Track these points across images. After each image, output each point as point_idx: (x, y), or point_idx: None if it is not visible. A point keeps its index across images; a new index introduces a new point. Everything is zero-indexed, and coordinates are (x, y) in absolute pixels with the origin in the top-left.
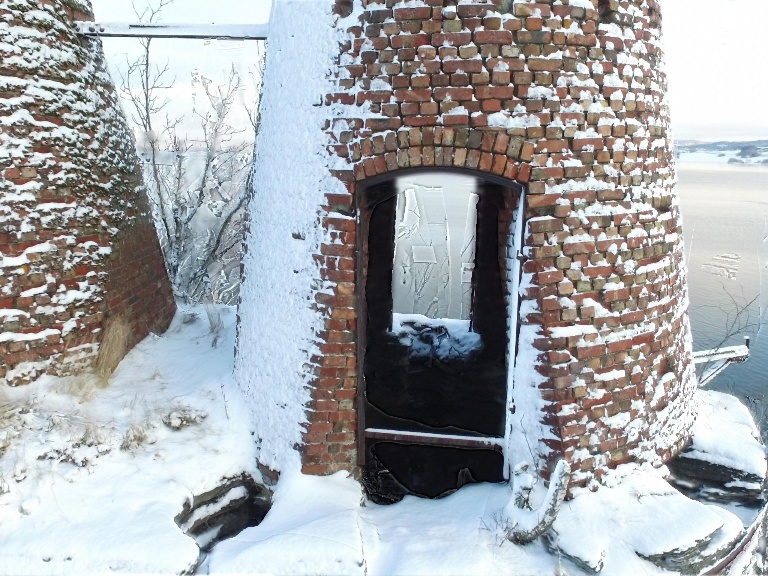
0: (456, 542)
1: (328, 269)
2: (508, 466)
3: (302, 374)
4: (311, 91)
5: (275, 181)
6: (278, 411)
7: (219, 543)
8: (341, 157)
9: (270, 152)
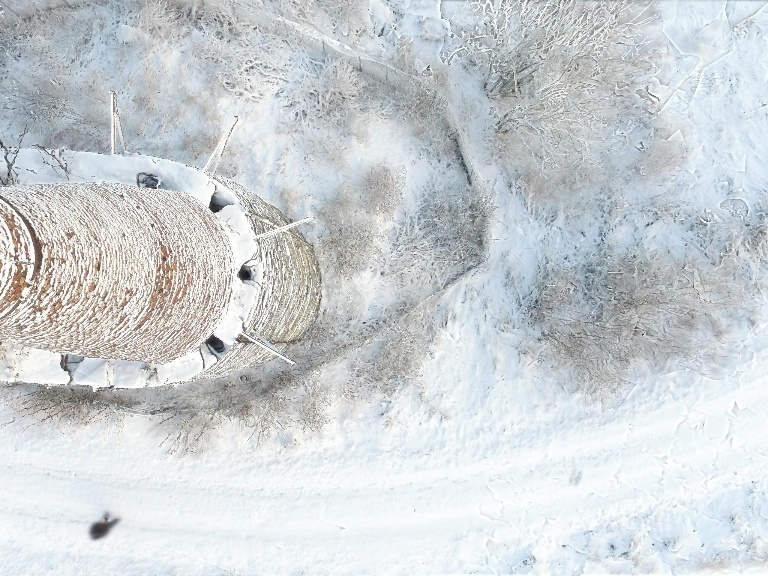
0: (132, 375)
1: None
2: None
3: None
4: None
5: None
6: None
7: (74, 372)
8: None
9: None
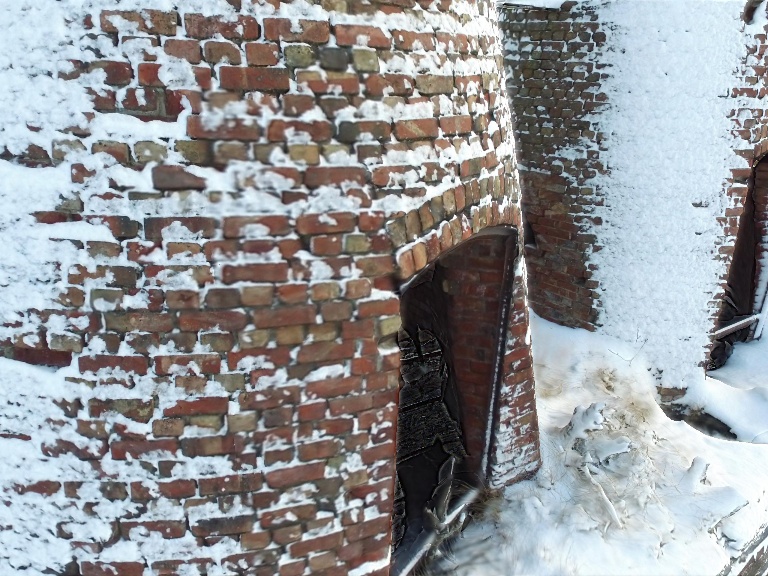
0: None
1: (731, 227)
2: (762, 330)
3: (708, 310)
4: (718, 84)
5: (666, 160)
6: (682, 344)
7: (759, 440)
8: (745, 139)
9: (651, 134)
